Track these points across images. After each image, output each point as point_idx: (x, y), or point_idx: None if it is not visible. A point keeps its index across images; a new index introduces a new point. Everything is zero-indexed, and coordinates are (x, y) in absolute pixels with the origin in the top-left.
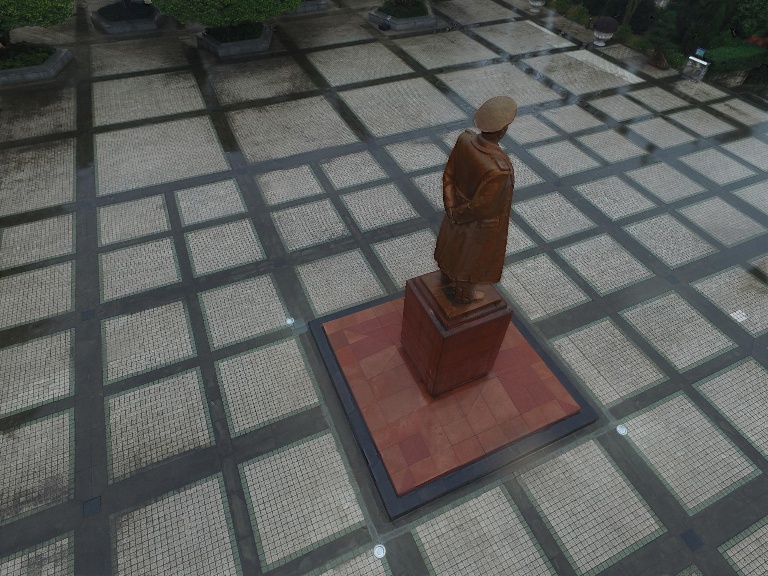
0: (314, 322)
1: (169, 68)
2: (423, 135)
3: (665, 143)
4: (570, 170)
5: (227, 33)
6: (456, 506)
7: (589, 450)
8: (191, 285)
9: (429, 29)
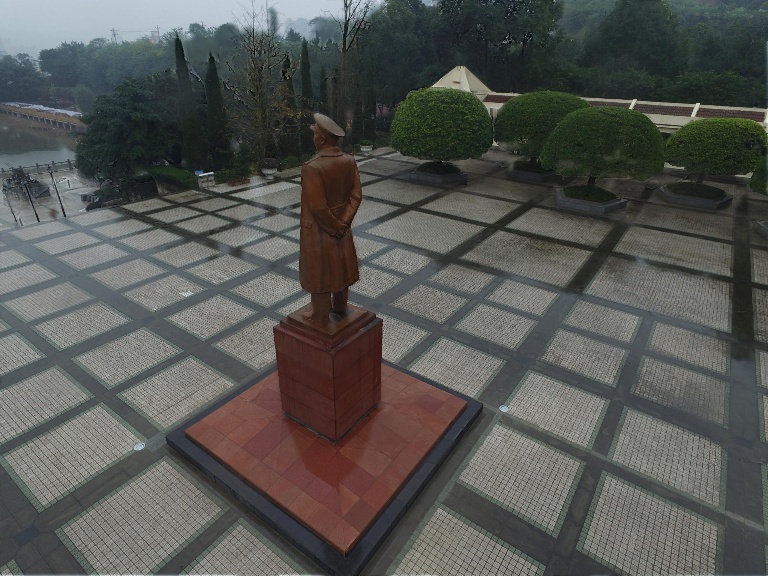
0: (345, 571)
1: None
2: None
3: None
4: None
5: None
6: None
7: None
8: None
9: None
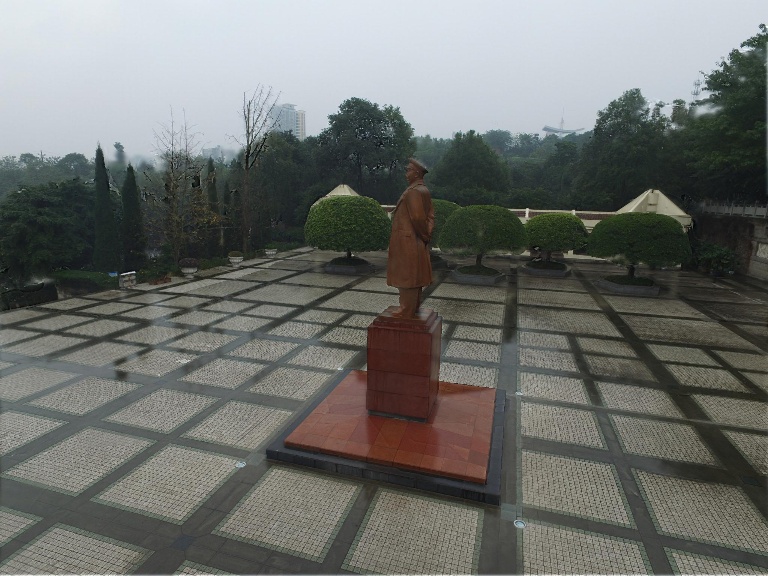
0: (492, 491)
1: None
2: None
3: None
4: None
5: None
6: None
7: None
8: None
9: None
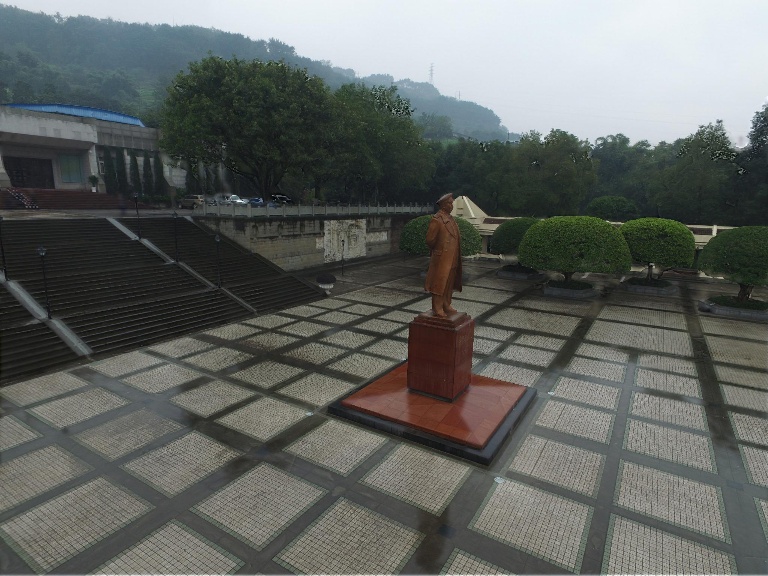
0: None
1: (507, 290)
2: (626, 349)
3: None
4: (750, 406)
5: (557, 282)
6: (357, 428)
7: (459, 467)
8: (387, 336)
9: (756, 320)
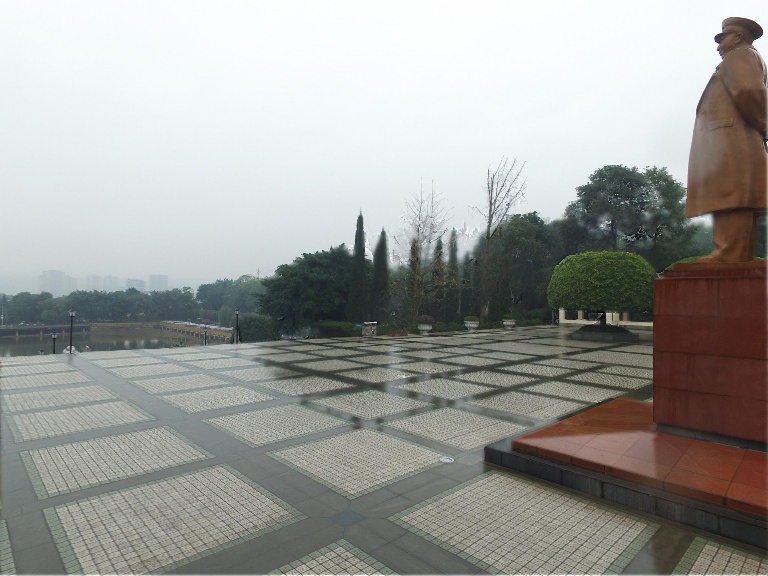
0: None
1: None
2: None
3: (78, 379)
4: (132, 414)
5: None
6: None
7: None
8: None
9: None
